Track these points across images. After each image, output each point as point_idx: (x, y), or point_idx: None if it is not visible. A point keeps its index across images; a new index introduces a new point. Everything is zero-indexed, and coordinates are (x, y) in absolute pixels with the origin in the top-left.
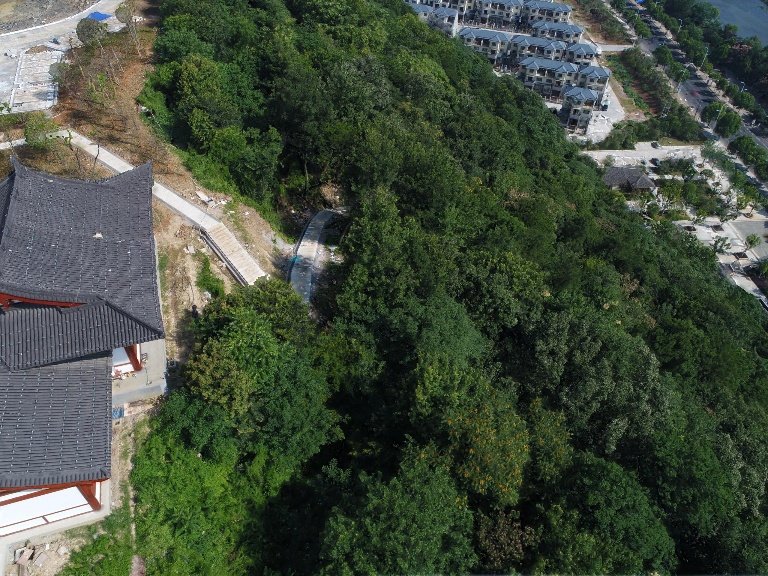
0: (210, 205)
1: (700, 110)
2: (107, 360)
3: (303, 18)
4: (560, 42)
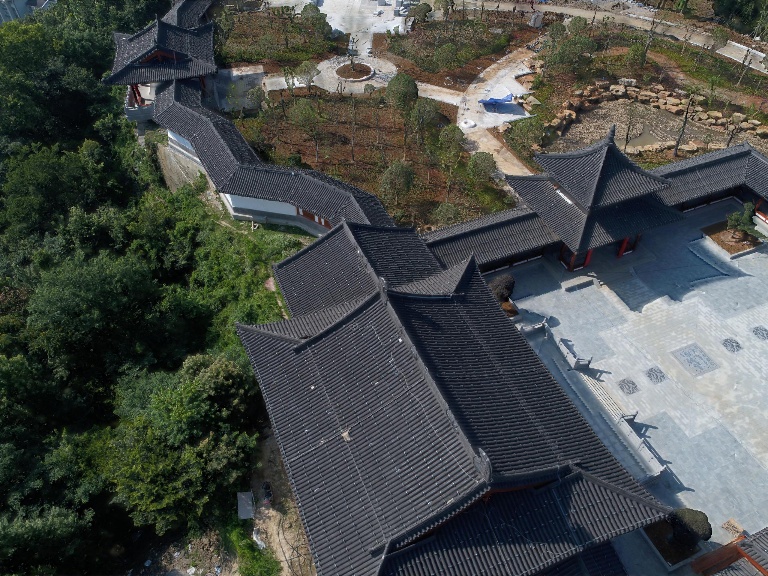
0: None
1: None
2: None
3: None
4: None
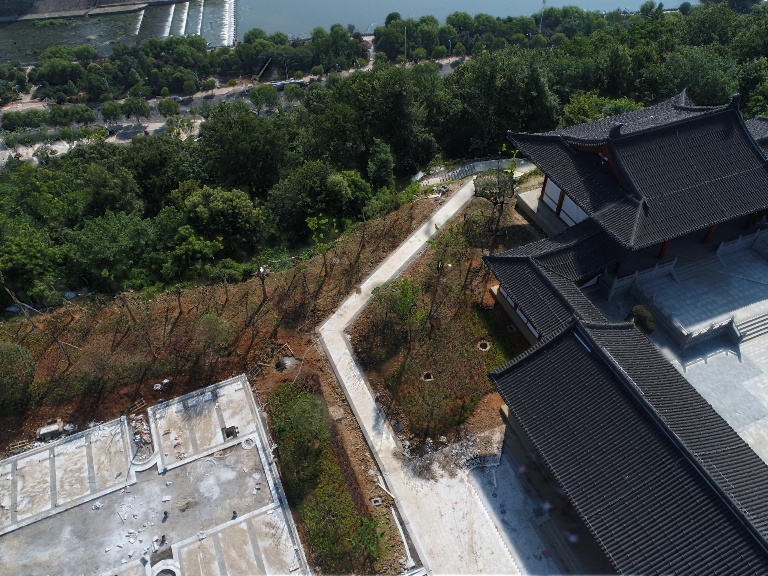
0: None
1: None
2: None
3: None
4: None
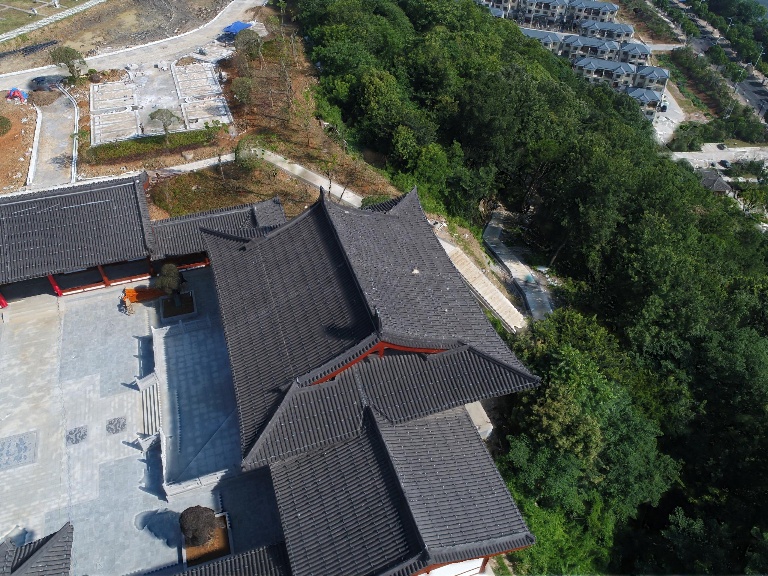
0: (436, 228)
1: (763, 111)
2: (463, 408)
3: (417, 24)
4: (613, 42)
